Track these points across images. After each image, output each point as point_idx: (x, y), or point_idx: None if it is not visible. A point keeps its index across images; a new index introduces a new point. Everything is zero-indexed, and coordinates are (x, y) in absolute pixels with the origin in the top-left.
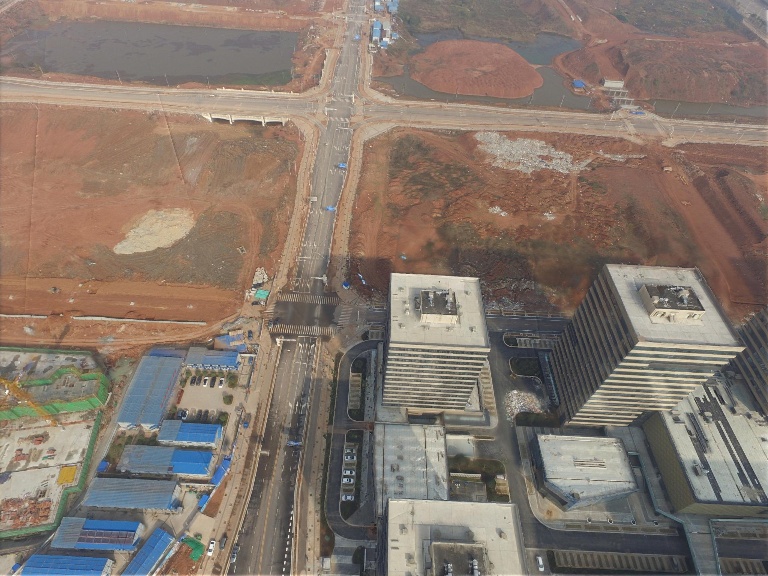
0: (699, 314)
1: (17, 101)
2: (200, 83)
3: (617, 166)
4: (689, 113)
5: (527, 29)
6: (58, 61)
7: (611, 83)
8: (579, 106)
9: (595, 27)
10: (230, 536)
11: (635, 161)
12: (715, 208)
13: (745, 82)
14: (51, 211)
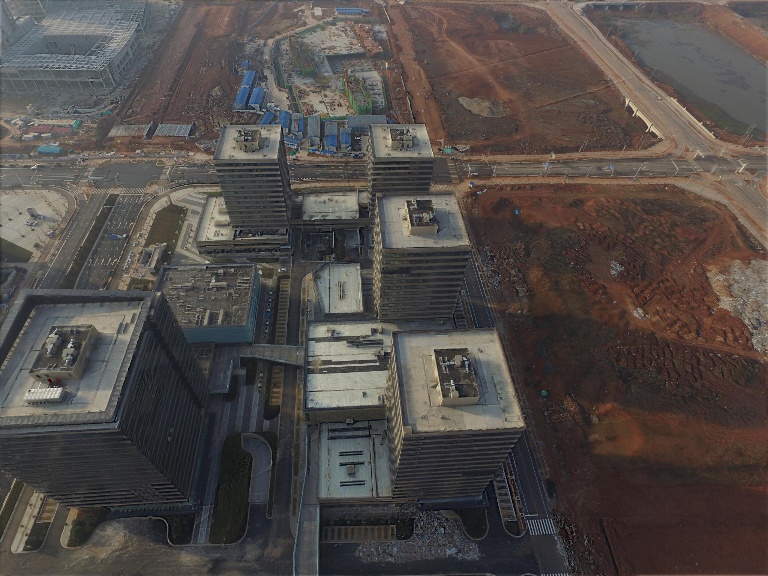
0: None
1: (572, 36)
2: (673, 90)
3: None
4: None
5: None
6: (639, 37)
7: None
8: None
9: None
10: (299, 162)
11: None
12: None
13: None
14: (481, 73)
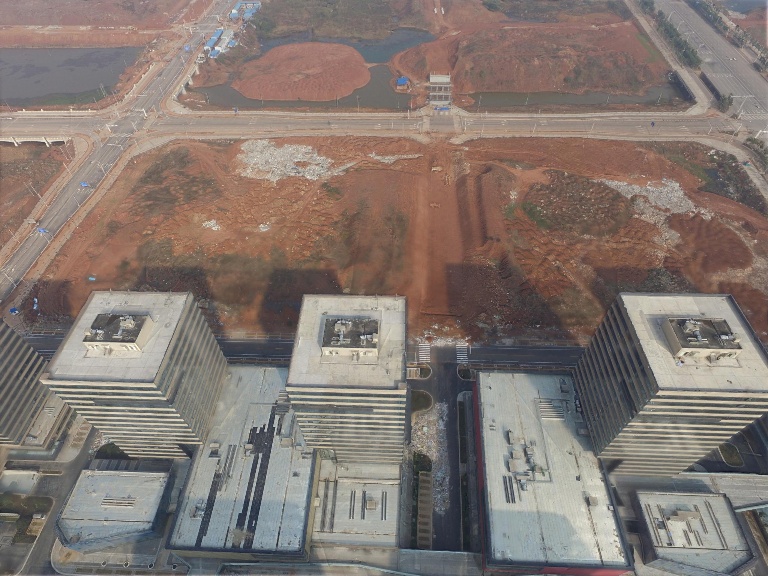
0: (133, 346)
1: None
2: (7, 106)
3: (374, 169)
4: (502, 105)
5: (384, 26)
6: None
7: (436, 78)
8: (392, 105)
9: (456, 18)
10: None
11: (402, 162)
12: (461, 209)
13: (582, 67)
14: None
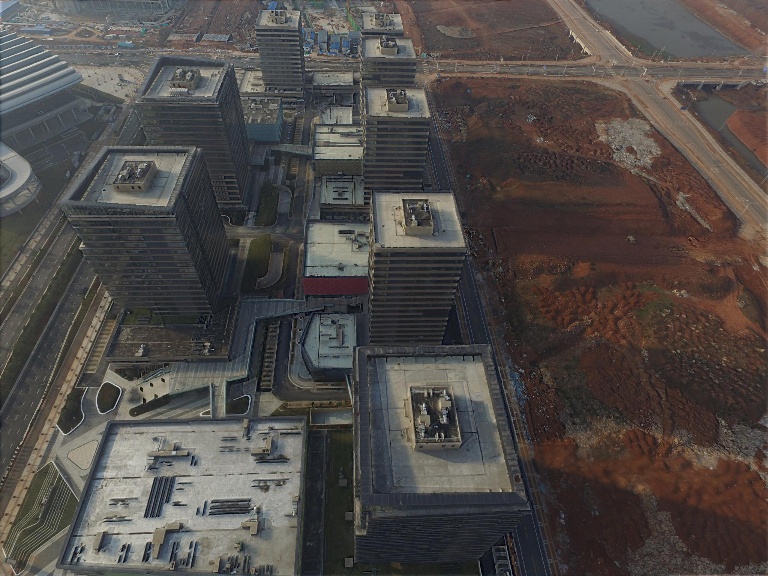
0: None
1: None
2: (610, 26)
3: None
4: None
5: None
6: None
7: None
8: None
9: None
10: None
11: (684, 213)
12: None
13: None
14: (457, 11)
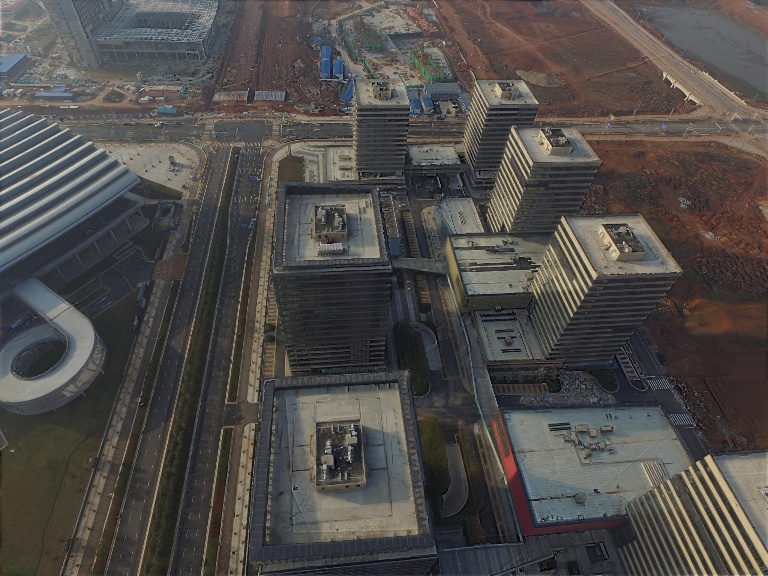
0: None
1: (605, 20)
2: (703, 66)
3: None
4: None
5: None
6: (664, 22)
7: None
8: None
9: None
10: None
11: None
12: None
13: None
14: (530, 50)
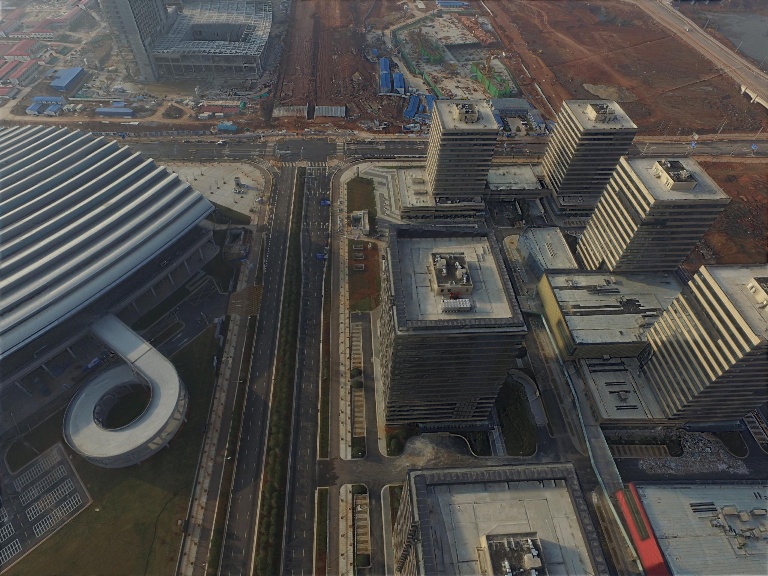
0: None
1: (671, 28)
2: None
3: None
4: None
5: None
6: (732, 30)
7: None
8: None
9: None
10: None
11: None
12: None
13: None
14: (595, 62)
